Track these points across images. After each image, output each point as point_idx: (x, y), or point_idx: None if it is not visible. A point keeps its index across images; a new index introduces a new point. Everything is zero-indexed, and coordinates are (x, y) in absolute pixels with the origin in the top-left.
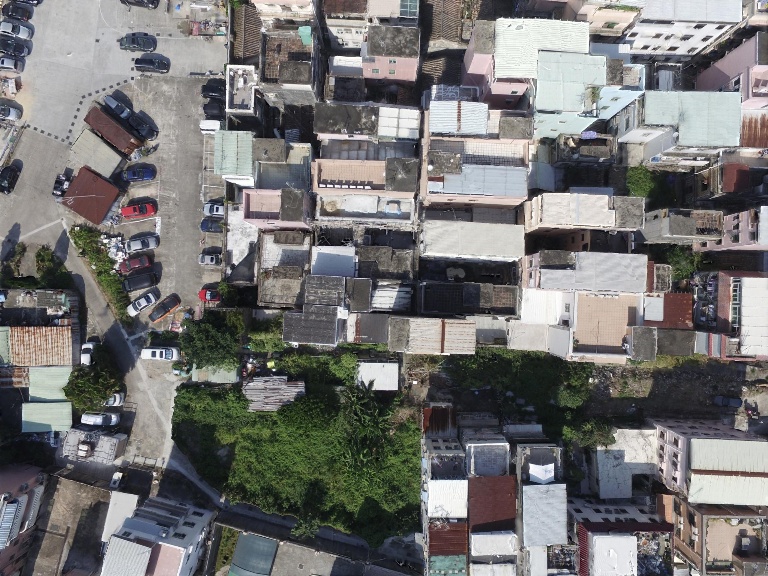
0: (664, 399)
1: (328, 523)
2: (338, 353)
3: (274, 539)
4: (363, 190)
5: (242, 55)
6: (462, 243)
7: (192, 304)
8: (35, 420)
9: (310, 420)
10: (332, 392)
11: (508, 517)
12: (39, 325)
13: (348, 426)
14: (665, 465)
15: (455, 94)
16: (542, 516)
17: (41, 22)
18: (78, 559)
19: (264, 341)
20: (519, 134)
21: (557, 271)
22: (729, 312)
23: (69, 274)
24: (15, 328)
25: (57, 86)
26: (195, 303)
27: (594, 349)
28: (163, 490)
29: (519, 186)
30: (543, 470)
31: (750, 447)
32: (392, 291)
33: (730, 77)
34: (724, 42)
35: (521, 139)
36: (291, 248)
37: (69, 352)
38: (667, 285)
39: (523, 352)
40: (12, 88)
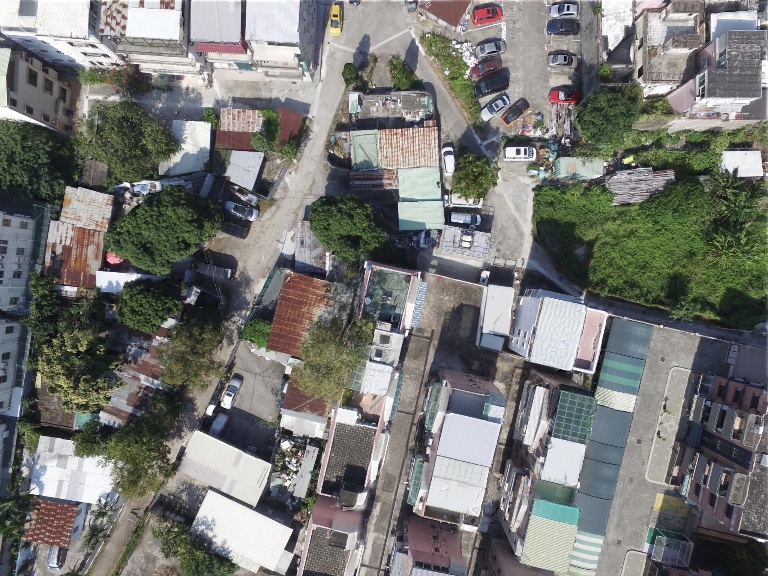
0: None
1: (696, 311)
2: (687, 150)
3: (651, 324)
4: None
5: None
6: None
7: (540, 108)
8: (410, 219)
9: (694, 199)
10: (696, 181)
11: None
12: (406, 127)
13: (708, 218)
14: None
15: None
16: None
17: None
18: (444, 360)
19: (624, 135)
20: None
21: None
22: None
23: (420, 82)
24: (383, 131)
25: None
26: (543, 107)
27: None
28: (524, 290)
29: None
30: None
31: None
32: None
33: None
34: None
35: None
36: (676, 25)
37: (435, 153)
38: None
39: None
40: None
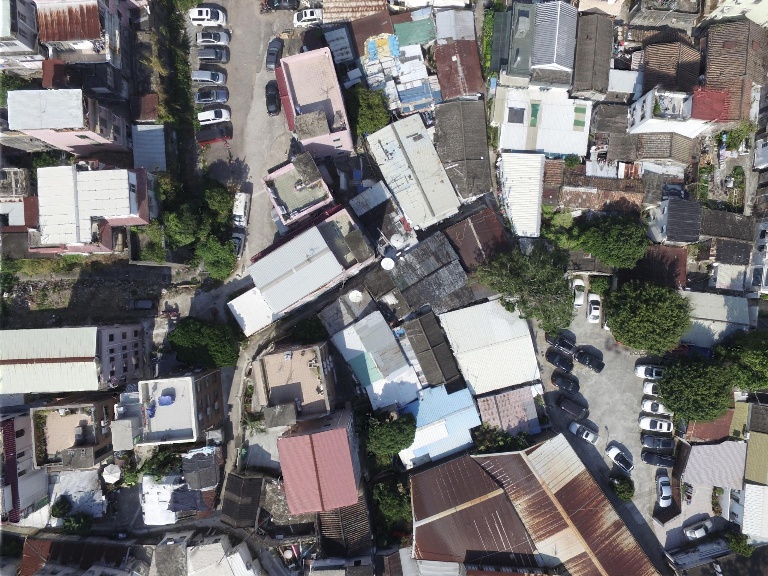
0: (83, 308)
1: None
2: None
3: None
4: None
5: None
6: None
7: None
8: None
9: None
10: None
11: None
12: None
13: None
14: None
15: None
16: None
17: None
18: None
19: None
20: None
21: None
22: None
23: None
24: None
25: None
26: None
27: None
28: None
29: None
30: None
31: (48, 334)
32: None
33: None
34: None
35: None
36: None
37: None
38: (25, 189)
39: None
40: None
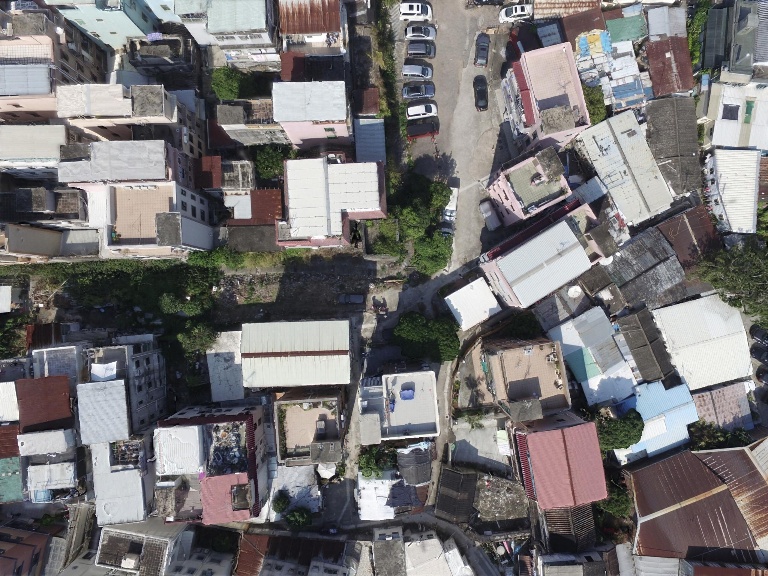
0: (291, 302)
1: None
2: None
3: None
4: None
5: None
6: None
7: None
8: None
9: None
10: None
11: (63, 416)
12: None
13: None
14: None
15: None
16: (100, 413)
17: None
18: None
19: None
20: (32, 30)
21: (72, 163)
22: None
23: None
24: None
25: None
26: None
27: (137, 242)
28: None
29: (41, 83)
30: (103, 368)
31: (301, 327)
32: None
33: None
34: None
35: (34, 35)
36: None
37: None
38: (252, 182)
39: (147, 266)
40: None
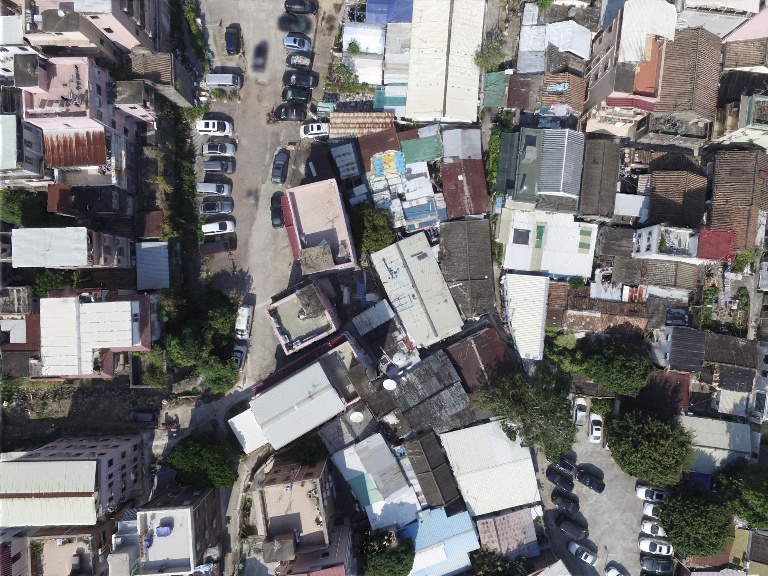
0: (83, 417)
1: None
2: None
3: None
4: None
5: None
6: None
7: None
8: None
9: None
10: None
11: None
12: None
13: None
14: None
15: None
16: None
17: None
18: None
19: None
20: None
21: None
22: None
23: None
24: None
25: None
26: None
27: None
28: None
29: None
30: None
31: (47, 468)
32: None
33: None
34: None
35: None
36: None
37: None
38: (27, 307)
39: None
40: None
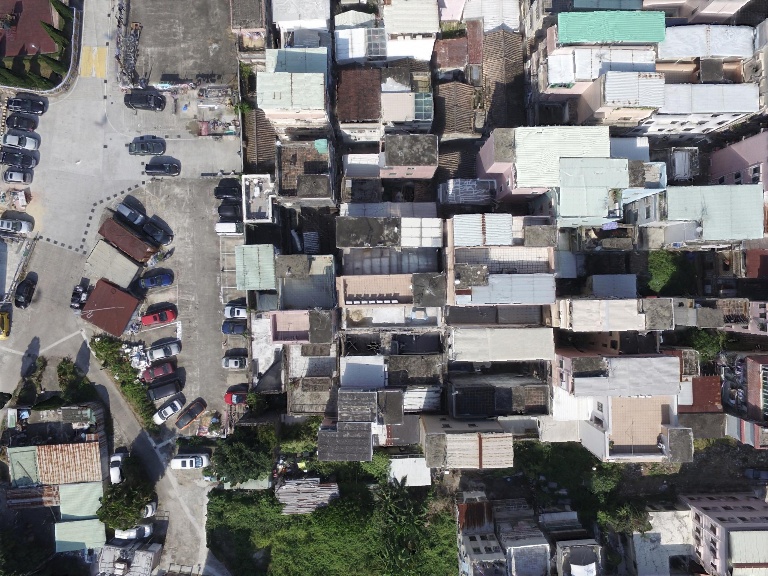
0: (695, 474)
1: None
2: None
3: None
4: (390, 305)
5: (256, 161)
6: (492, 351)
7: (218, 407)
8: (68, 539)
9: (346, 525)
10: (365, 491)
11: None
12: (66, 442)
13: (383, 522)
14: (702, 549)
15: (472, 188)
16: None
17: (47, 131)
18: None
19: None
20: (544, 242)
21: (590, 379)
22: (760, 399)
23: (92, 385)
24: (42, 447)
25: (67, 195)
26: (221, 406)
27: (630, 449)
28: None
29: (547, 293)
30: (585, 570)
31: None
32: (421, 392)
33: (749, 163)
34: (740, 124)
35: None
36: None
37: (98, 467)
38: (695, 369)
39: None
40: (22, 201)
